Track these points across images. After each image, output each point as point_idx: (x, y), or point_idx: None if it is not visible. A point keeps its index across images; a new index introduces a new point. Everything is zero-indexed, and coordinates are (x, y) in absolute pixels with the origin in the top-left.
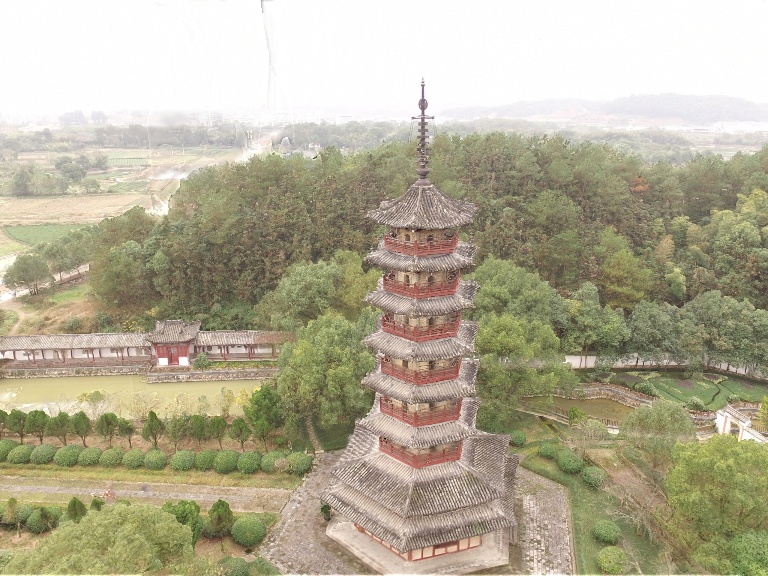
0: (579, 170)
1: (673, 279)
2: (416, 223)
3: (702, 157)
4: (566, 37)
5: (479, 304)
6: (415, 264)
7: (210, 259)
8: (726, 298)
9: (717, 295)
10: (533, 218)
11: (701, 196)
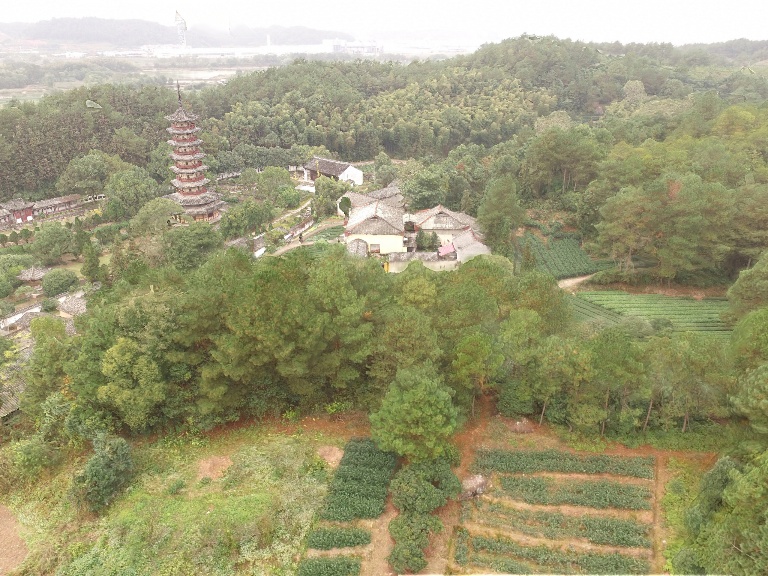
0: (168, 101)
1: (224, 142)
2: (189, 119)
3: (206, 88)
4: (77, 6)
5: (170, 158)
6: (190, 131)
7: (6, 169)
8: (246, 145)
9: (243, 144)
10: (158, 125)
11: (213, 108)
